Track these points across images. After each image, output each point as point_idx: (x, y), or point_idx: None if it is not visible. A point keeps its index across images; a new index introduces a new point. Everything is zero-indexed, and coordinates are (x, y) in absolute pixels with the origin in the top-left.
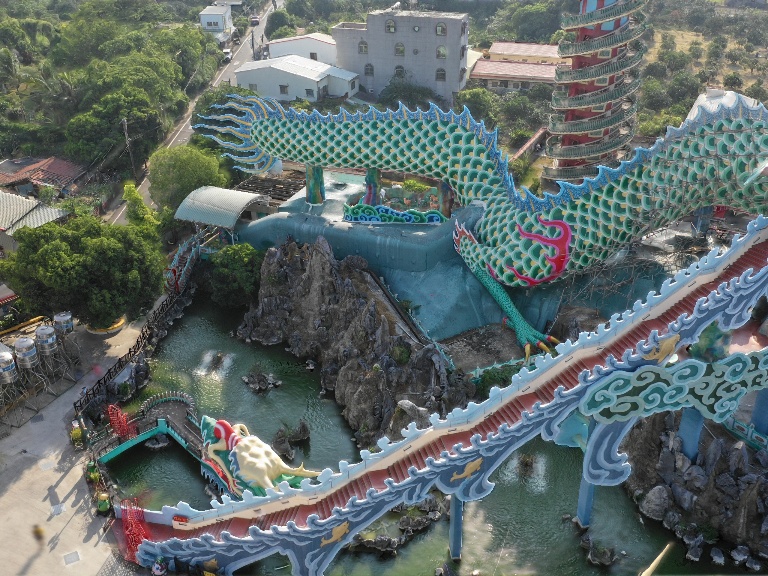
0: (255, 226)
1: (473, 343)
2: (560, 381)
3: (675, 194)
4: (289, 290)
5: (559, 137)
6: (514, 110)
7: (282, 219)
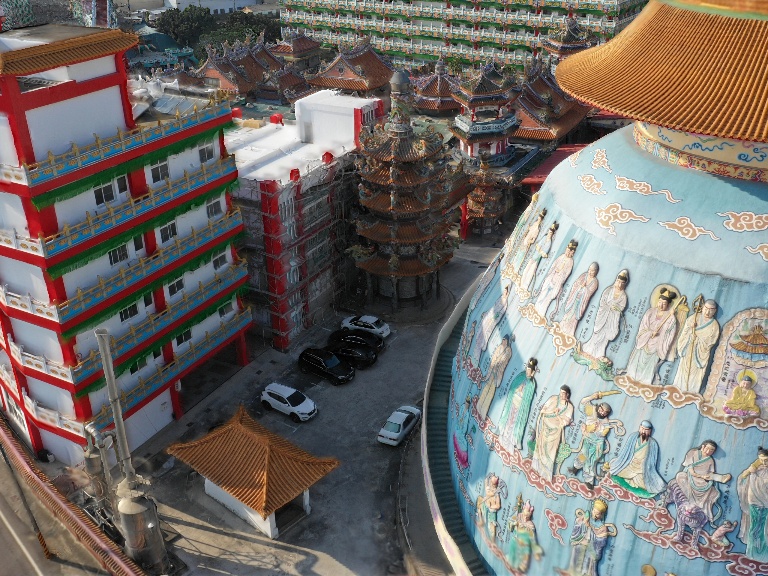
0: None
1: None
2: None
3: (10, 16)
4: None
5: None
6: None
7: None
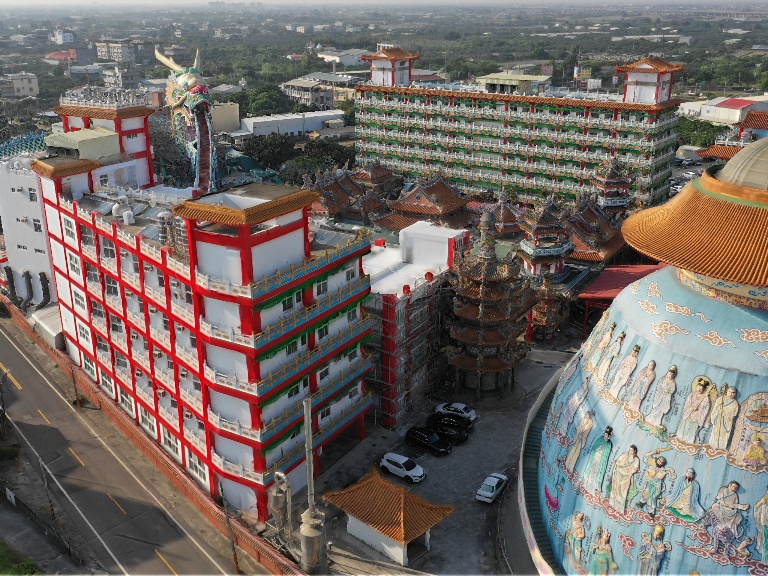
0: None
1: None
2: (202, 164)
3: None
4: None
5: None
6: None
7: None
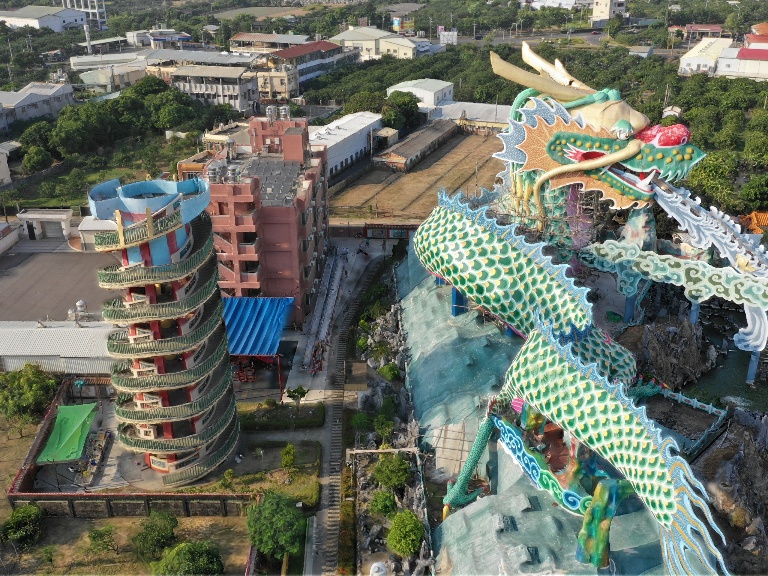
0: None
1: (668, 426)
2: None
3: None
4: None
5: (79, 462)
6: None
7: None
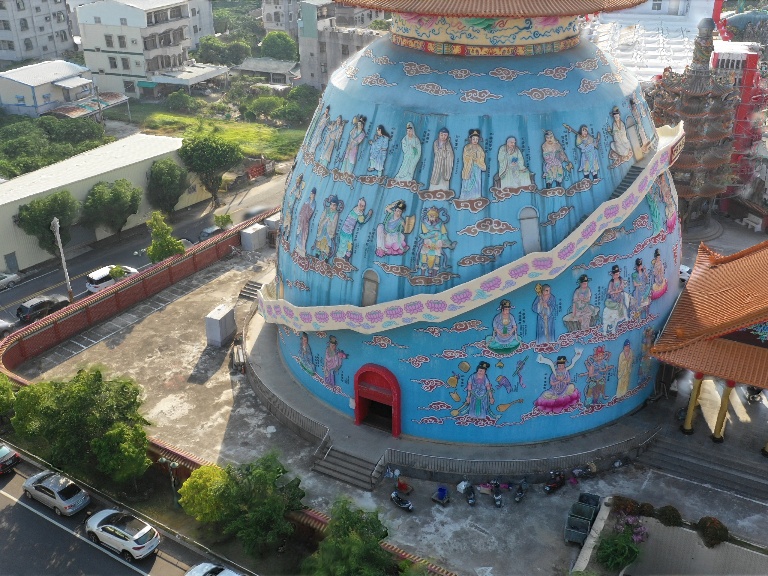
0: (727, 20)
1: None
2: None
3: None
4: (764, 38)
5: None
6: (749, 1)
7: (745, 14)
